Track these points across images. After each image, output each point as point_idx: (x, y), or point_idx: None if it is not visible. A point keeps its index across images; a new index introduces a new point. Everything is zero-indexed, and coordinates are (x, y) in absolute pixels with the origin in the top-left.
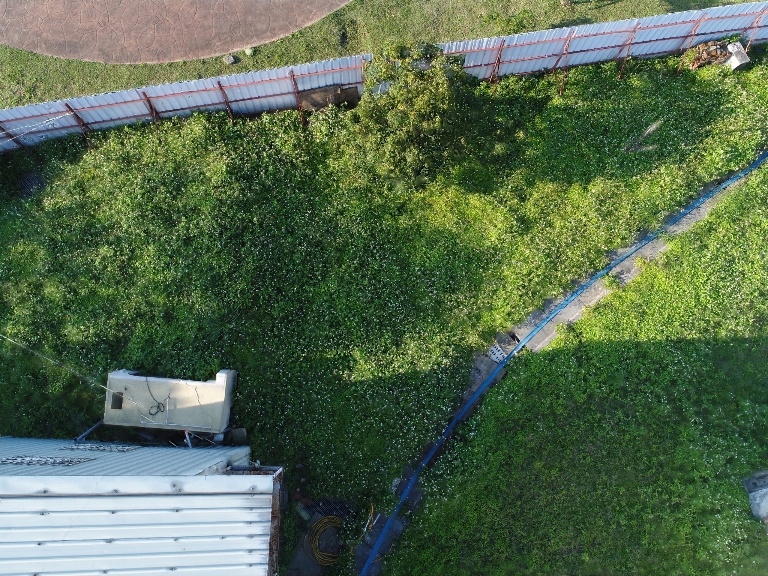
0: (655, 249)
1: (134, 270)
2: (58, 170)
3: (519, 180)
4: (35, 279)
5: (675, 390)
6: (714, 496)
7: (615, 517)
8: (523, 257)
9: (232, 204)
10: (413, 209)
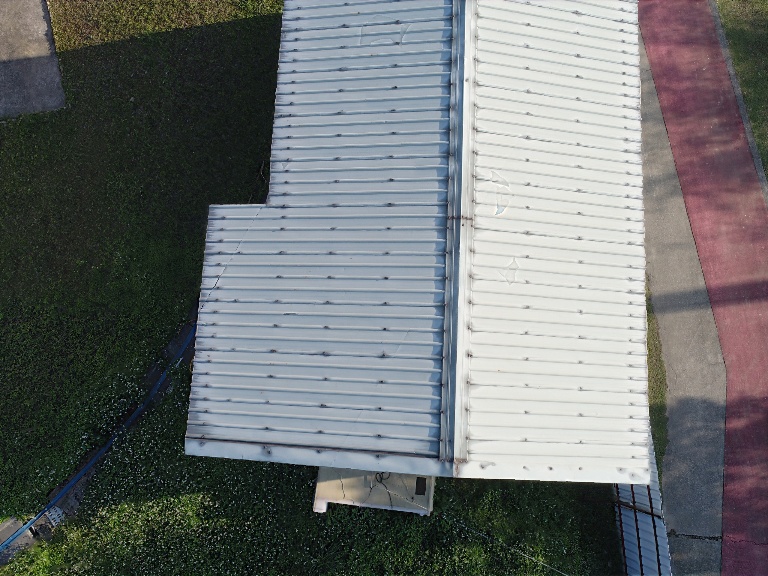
0: None
1: None
2: None
3: None
4: None
5: None
6: None
7: None
8: None
9: None
10: None
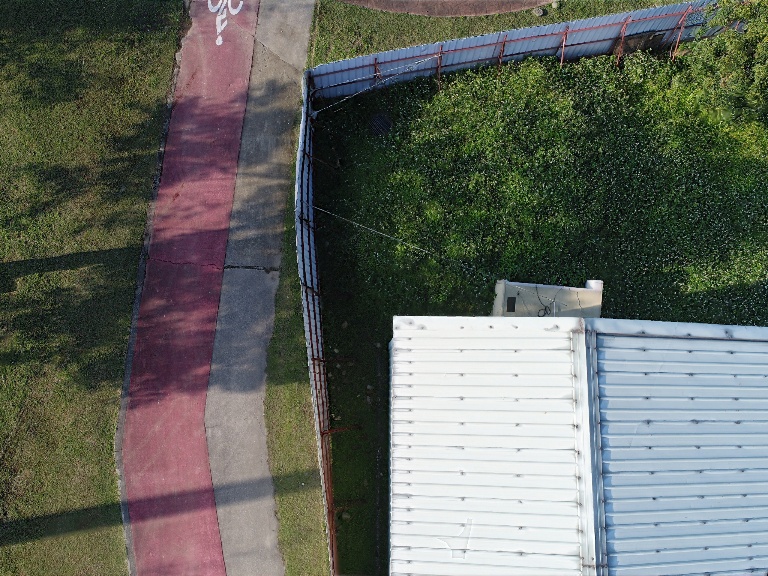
0: None
1: None
2: (416, 108)
3: None
4: (417, 202)
5: None
6: None
7: None
8: None
9: (580, 135)
10: None
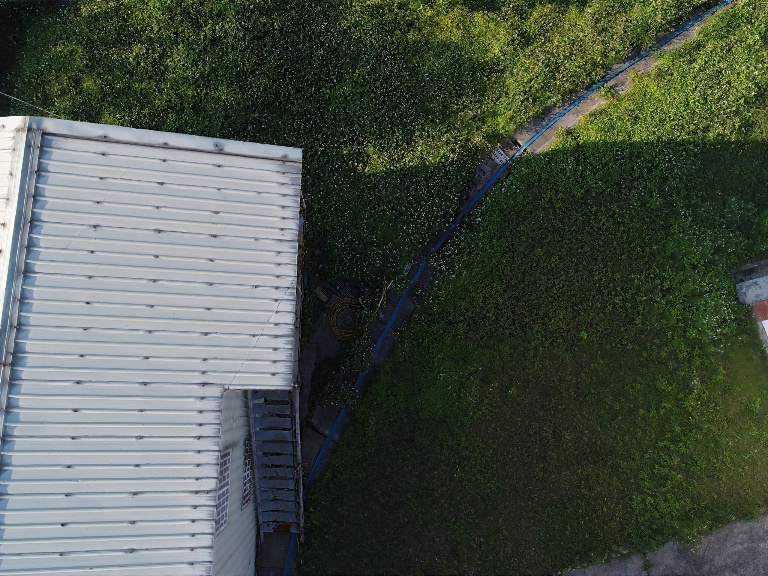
0: (647, 65)
1: (165, 67)
2: None
3: (520, 1)
4: (74, 74)
5: (666, 186)
6: (703, 280)
7: (611, 300)
8: (524, 68)
9: (254, 10)
10: (421, 27)
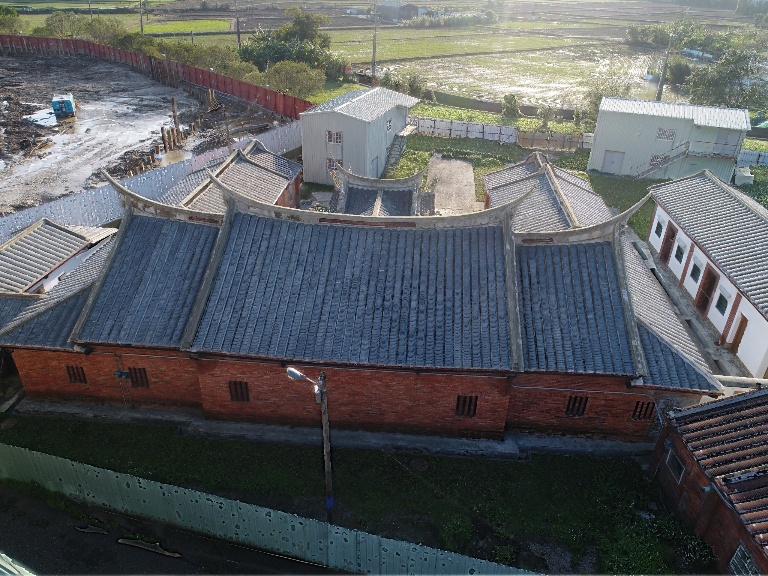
0: None
1: None
2: None
3: None
4: None
5: None
6: None
7: None
8: None
9: None
10: None
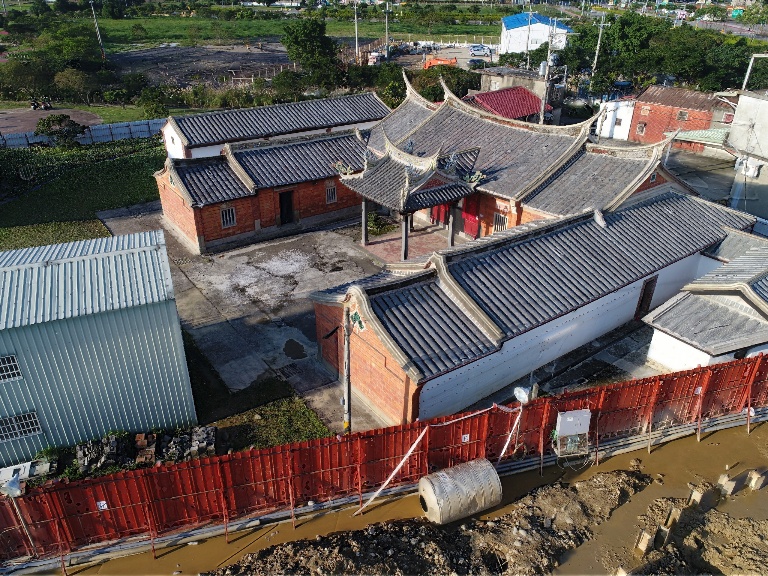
0: None
1: None
2: None
3: None
4: None
5: None
6: None
7: None
8: None
9: None
10: None
